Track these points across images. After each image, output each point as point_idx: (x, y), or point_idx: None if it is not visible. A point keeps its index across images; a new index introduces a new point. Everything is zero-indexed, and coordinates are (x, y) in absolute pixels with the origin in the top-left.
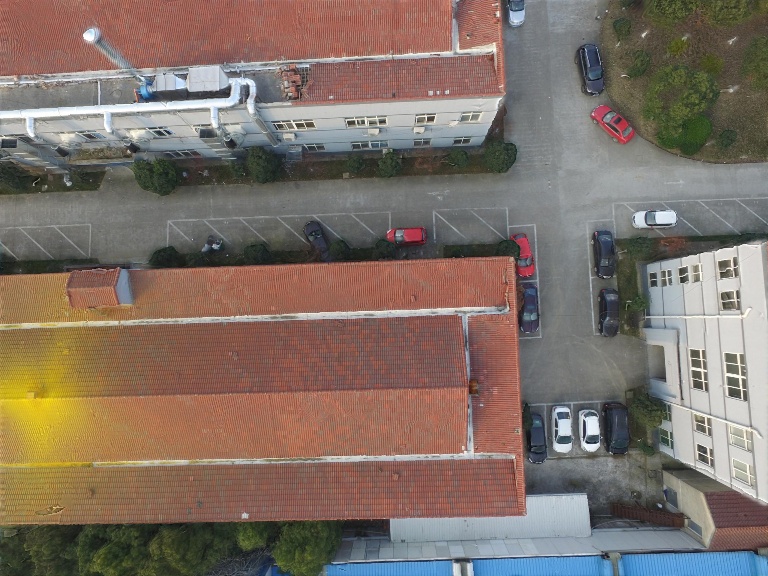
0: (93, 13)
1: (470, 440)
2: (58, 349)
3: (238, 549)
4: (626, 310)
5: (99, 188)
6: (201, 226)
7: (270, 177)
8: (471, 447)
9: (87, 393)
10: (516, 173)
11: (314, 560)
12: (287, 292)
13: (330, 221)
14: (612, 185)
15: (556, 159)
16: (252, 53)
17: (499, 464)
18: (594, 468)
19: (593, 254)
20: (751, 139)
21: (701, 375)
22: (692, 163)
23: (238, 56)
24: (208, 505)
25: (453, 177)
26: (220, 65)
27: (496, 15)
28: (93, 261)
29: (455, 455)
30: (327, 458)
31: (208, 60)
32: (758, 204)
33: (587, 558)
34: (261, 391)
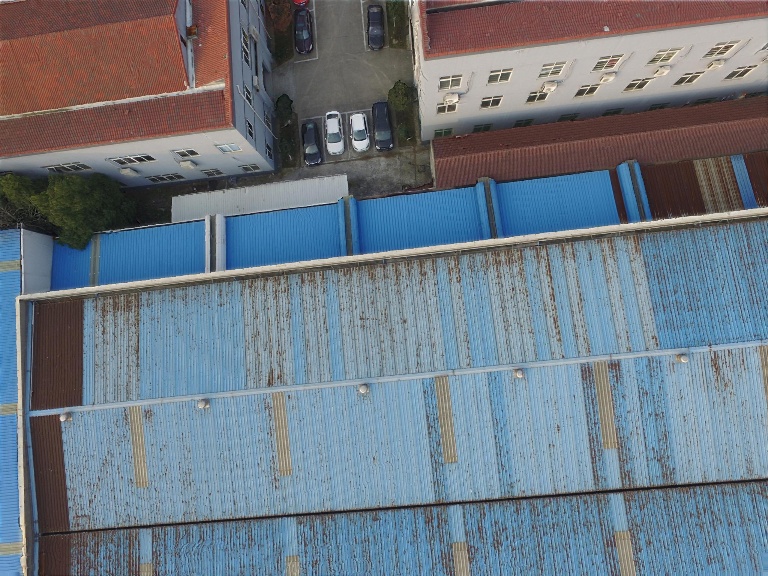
0: None
1: (193, 79)
2: None
3: (4, 198)
4: (394, 27)
5: None
6: None
7: None
8: (193, 84)
9: None
10: None
11: (64, 197)
12: None
13: None
14: None
15: None
16: None
17: (216, 94)
18: (368, 168)
19: None
20: None
21: None
22: None
23: None
24: None
25: None
26: None
27: None
28: None
29: (180, 92)
30: (73, 107)
31: None
32: None
33: (328, 206)
34: None
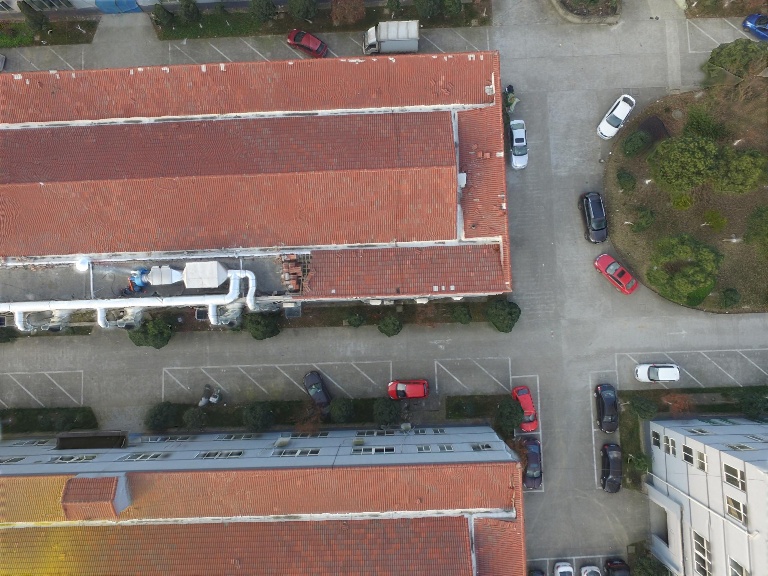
0: (84, 200)
1: None
2: (53, 553)
3: None
4: (628, 463)
5: (91, 333)
6: (197, 374)
7: (269, 336)
8: None
9: None
10: (519, 322)
11: None
12: (290, 496)
13: (330, 370)
14: (615, 335)
15: (559, 308)
16: (251, 239)
17: None
18: None
19: (596, 407)
20: (753, 289)
21: (705, 563)
22: (695, 313)
23: (236, 242)
24: None
25: (455, 325)
26: (218, 250)
27: (502, 207)
28: (86, 410)
29: None
30: None
31: (205, 245)
32: (759, 355)
33: None
34: None
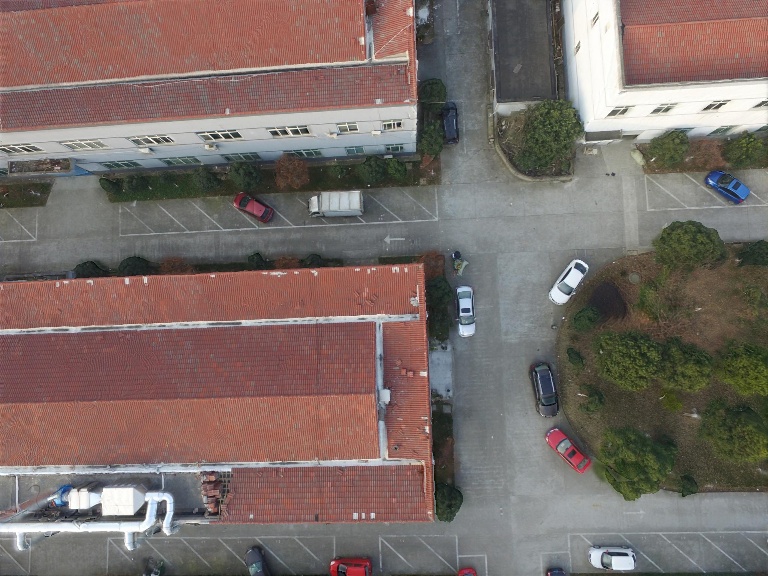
0: (6, 420)
1: None
2: None
3: None
4: None
5: None
6: (141, 545)
7: None
8: None
9: None
10: (466, 497)
11: None
12: None
13: (273, 544)
14: (568, 514)
15: (508, 483)
16: (172, 456)
17: None
18: None
19: None
20: (717, 467)
21: None
22: None
23: (158, 458)
24: None
25: None
26: (140, 464)
27: (425, 430)
28: None
29: None
30: None
31: (127, 461)
32: (724, 539)
33: None
34: None
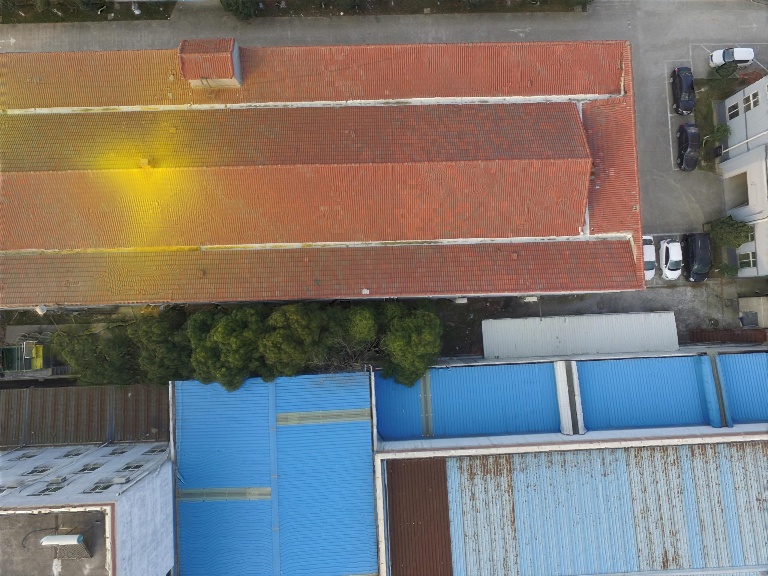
0: None
1: (585, 223)
2: (163, 128)
3: (351, 335)
4: (703, 147)
5: (170, 17)
6: None
7: None
8: (586, 229)
9: (202, 164)
10: (596, 13)
11: (430, 342)
12: (404, 73)
13: None
14: (689, 27)
15: (635, 0)
16: None
17: (615, 244)
18: (674, 297)
19: (672, 92)
20: None
21: None
22: (764, 8)
23: None
24: (326, 282)
25: (535, 15)
26: None
27: None
28: None
29: (571, 237)
30: (443, 241)
31: None
32: None
33: (684, 358)
34: (384, 162)
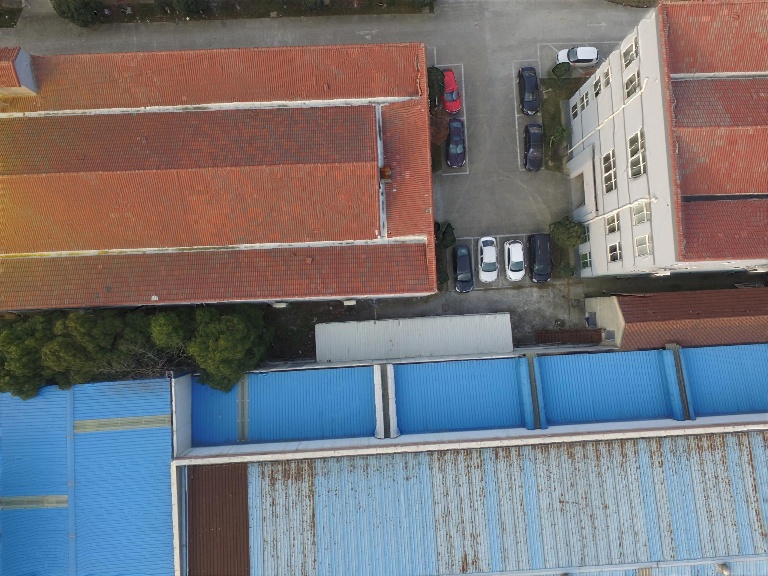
0: None
1: (384, 226)
2: None
3: (151, 342)
4: (550, 147)
5: (16, 25)
6: None
7: (192, 2)
8: (385, 233)
9: None
10: (444, 14)
11: (228, 348)
12: (197, 78)
13: None
14: (537, 26)
15: (483, 1)
16: None
17: (412, 248)
18: (519, 298)
19: (518, 92)
20: None
21: (611, 176)
22: (614, 6)
23: None
24: (117, 289)
25: (381, 17)
26: None
27: None
28: None
29: (369, 241)
30: (241, 246)
31: None
32: None
33: (505, 360)
34: (169, 168)
